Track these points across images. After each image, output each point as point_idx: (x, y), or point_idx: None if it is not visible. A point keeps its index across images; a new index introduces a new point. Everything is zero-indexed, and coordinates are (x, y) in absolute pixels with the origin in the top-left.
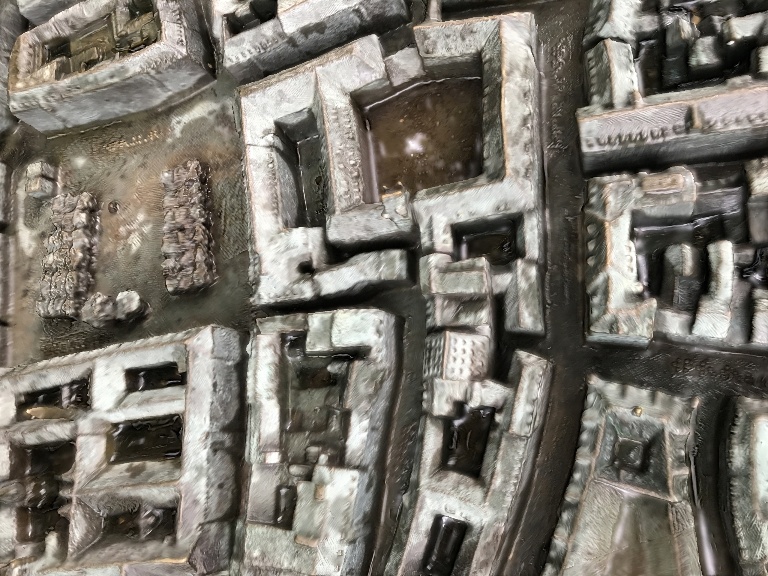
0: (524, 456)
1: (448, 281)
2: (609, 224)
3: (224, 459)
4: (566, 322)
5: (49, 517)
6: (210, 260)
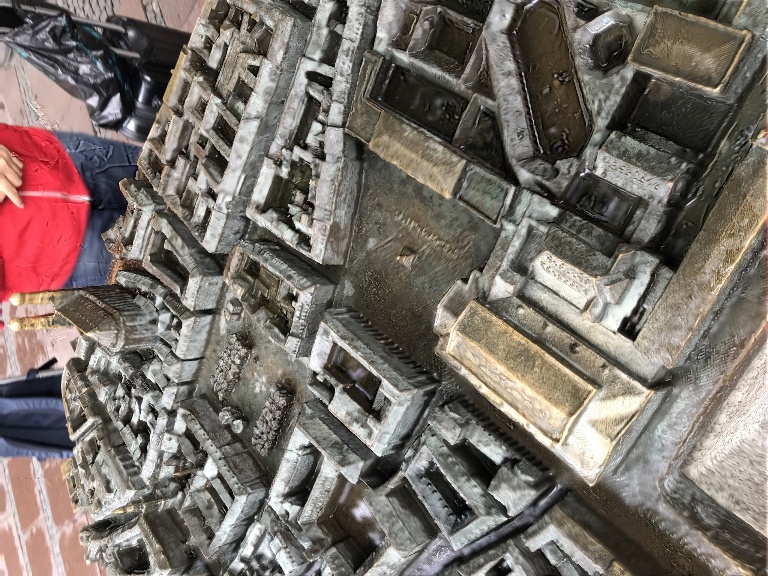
0: None
1: None
2: None
3: None
4: None
5: None
6: (272, 445)
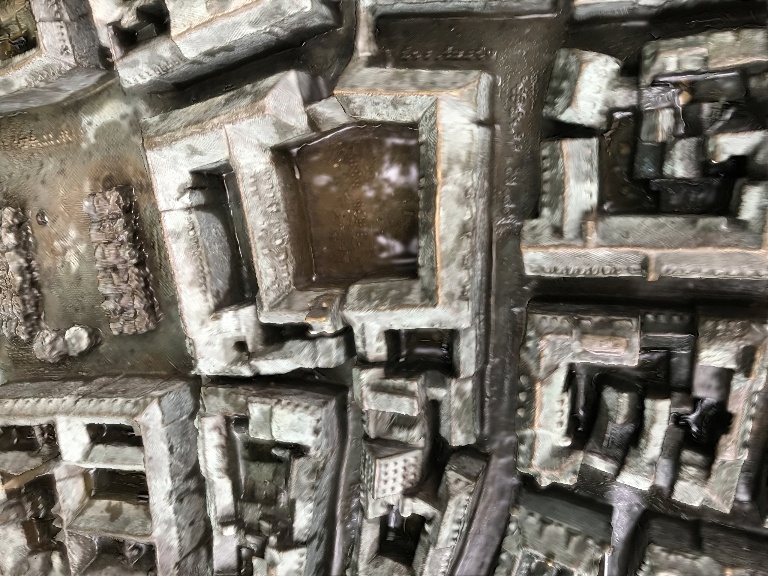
0: (451, 556)
1: (380, 401)
2: (541, 384)
3: (192, 500)
4: (504, 417)
5: (52, 525)
6: (150, 302)
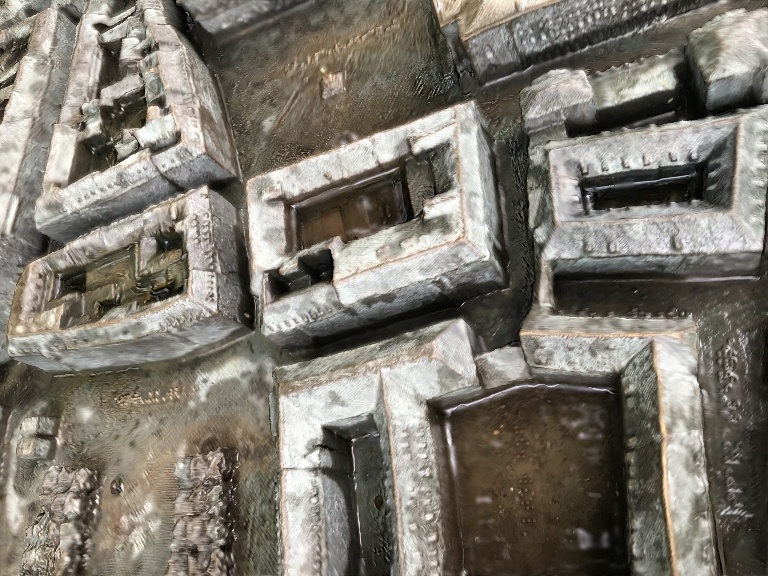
0: None
1: None
2: None
3: None
4: None
5: None
6: None
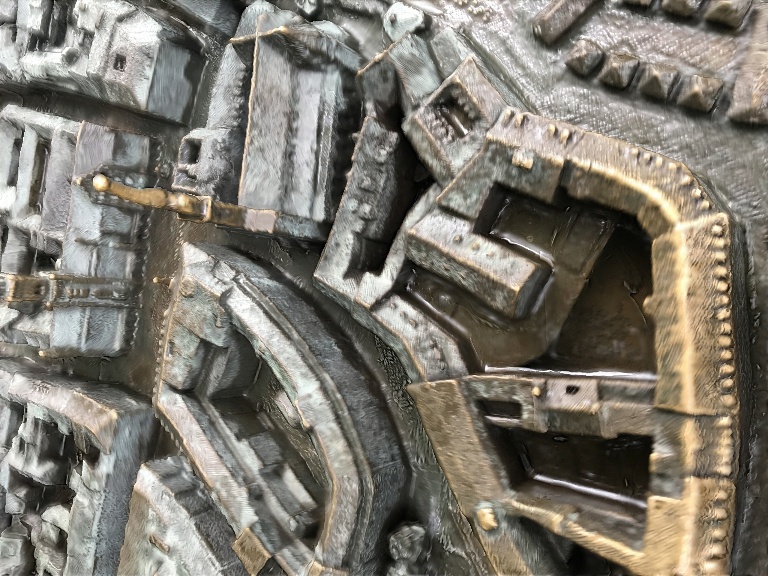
0: None
1: None
2: None
3: None
4: None
5: None
6: None
